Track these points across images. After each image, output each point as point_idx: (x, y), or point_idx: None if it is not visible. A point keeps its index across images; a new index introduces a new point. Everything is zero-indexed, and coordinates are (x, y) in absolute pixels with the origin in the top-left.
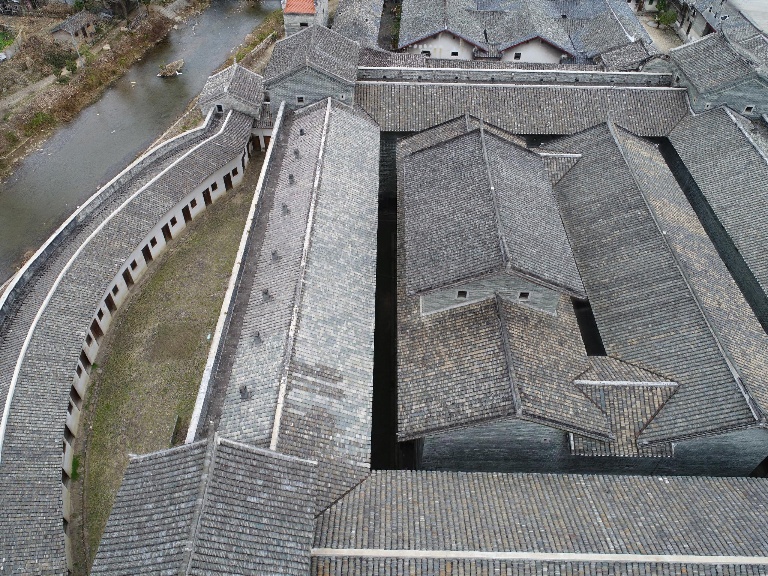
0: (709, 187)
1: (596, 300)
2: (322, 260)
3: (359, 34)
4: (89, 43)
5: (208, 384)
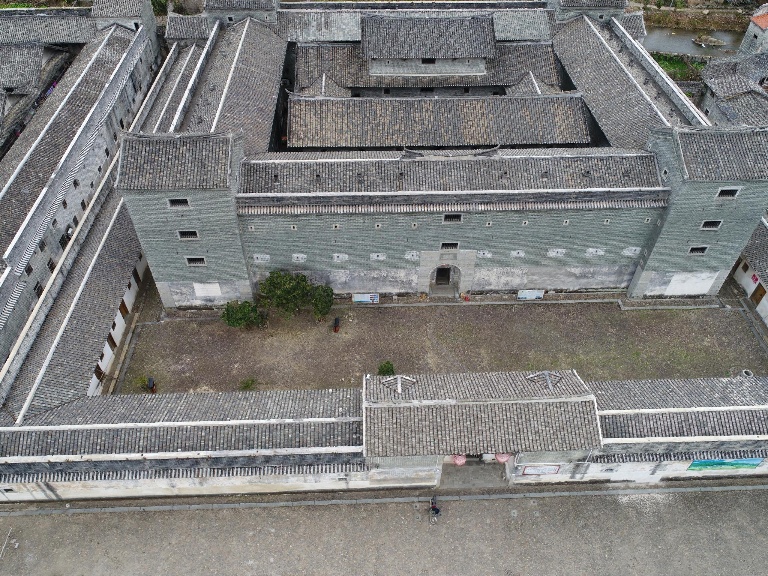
0: None
1: None
2: None
3: (765, 60)
4: (704, 5)
5: (320, 4)
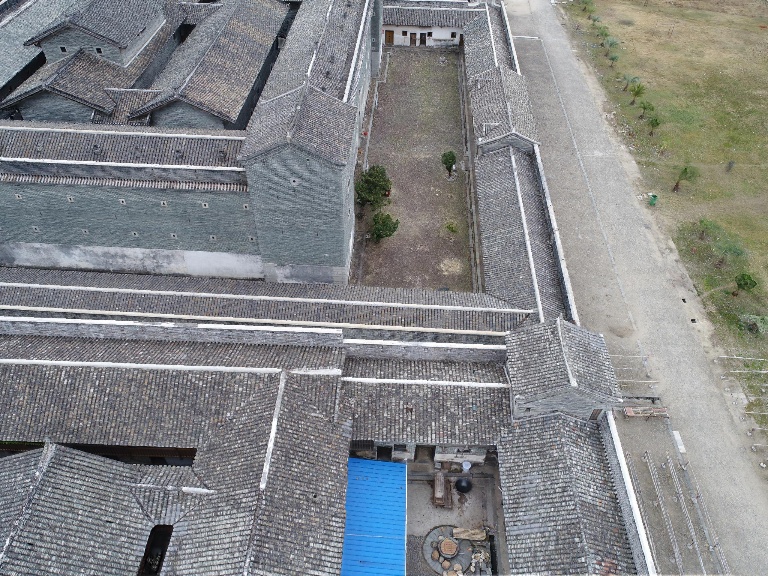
0: (296, 23)
1: (167, 68)
2: (1, 39)
3: None
4: None
5: None
